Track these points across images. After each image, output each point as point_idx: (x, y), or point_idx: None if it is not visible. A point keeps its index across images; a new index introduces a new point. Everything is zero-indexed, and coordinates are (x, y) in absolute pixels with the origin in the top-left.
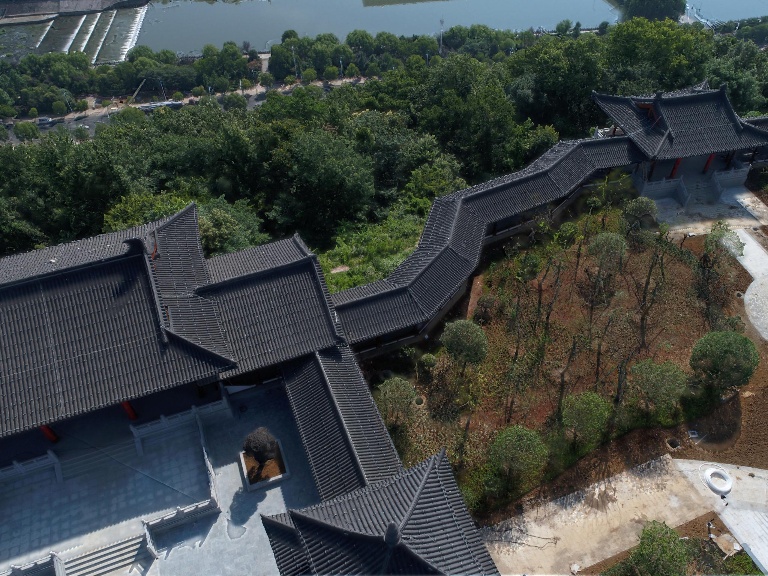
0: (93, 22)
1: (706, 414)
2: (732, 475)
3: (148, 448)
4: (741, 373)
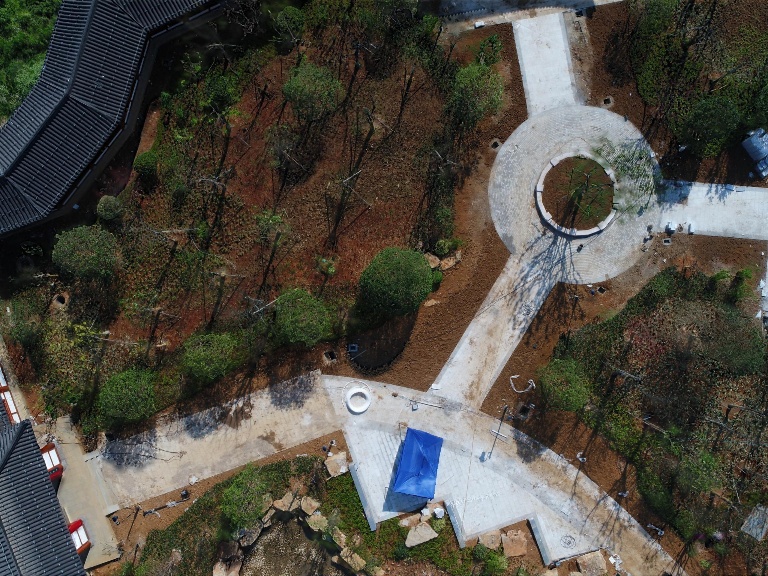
0: None
1: (373, 328)
2: (375, 394)
3: None
4: (402, 310)
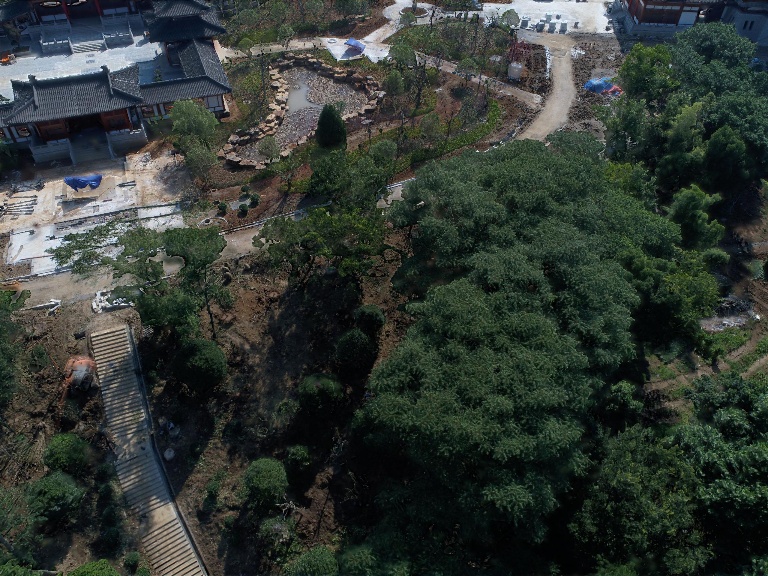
0: None
1: (339, 28)
2: (339, 40)
3: (107, 29)
4: (349, 6)
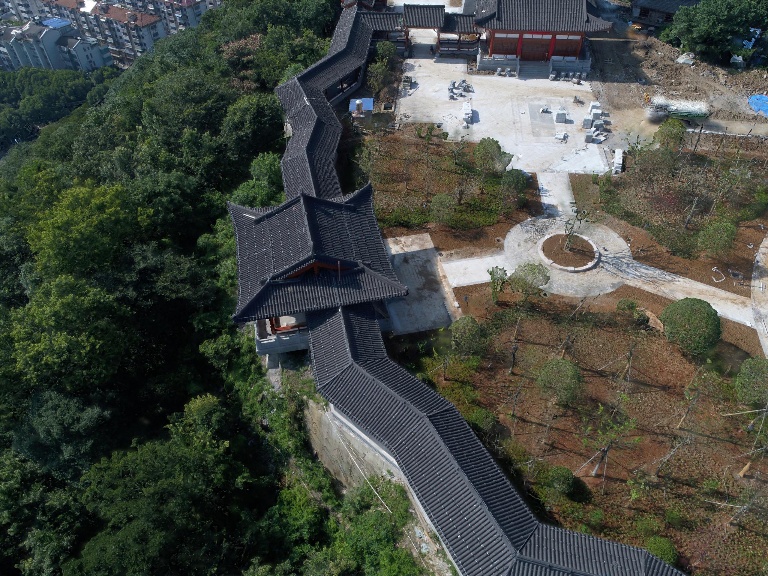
0: None
1: (725, 361)
2: None
3: None
4: None
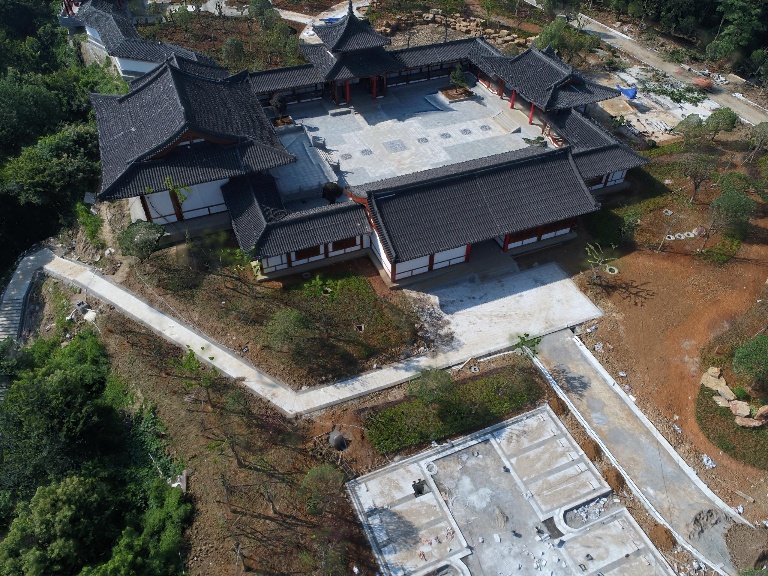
0: None
1: None
2: None
3: None
4: None
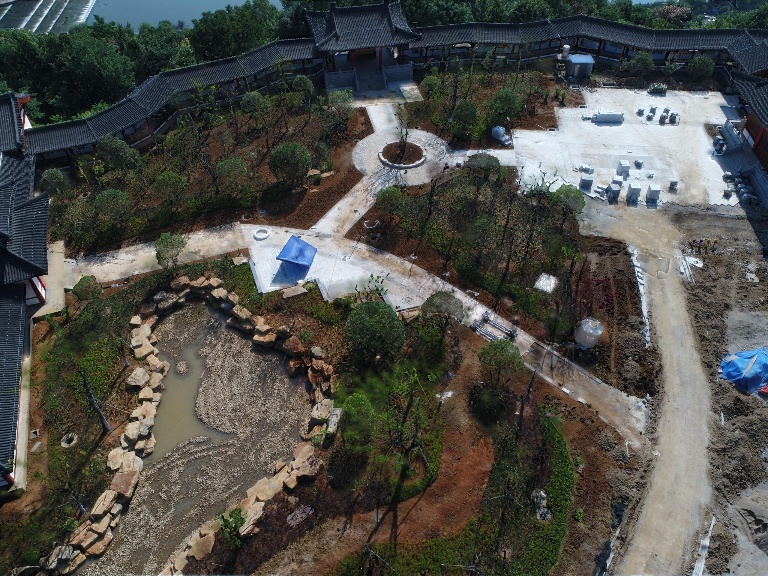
0: (48, 6)
1: (277, 200)
2: (273, 231)
3: None
4: (291, 167)
